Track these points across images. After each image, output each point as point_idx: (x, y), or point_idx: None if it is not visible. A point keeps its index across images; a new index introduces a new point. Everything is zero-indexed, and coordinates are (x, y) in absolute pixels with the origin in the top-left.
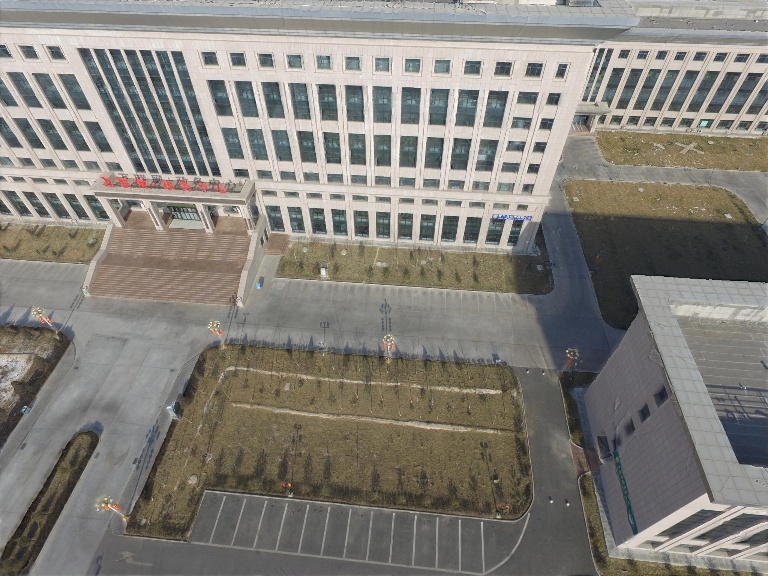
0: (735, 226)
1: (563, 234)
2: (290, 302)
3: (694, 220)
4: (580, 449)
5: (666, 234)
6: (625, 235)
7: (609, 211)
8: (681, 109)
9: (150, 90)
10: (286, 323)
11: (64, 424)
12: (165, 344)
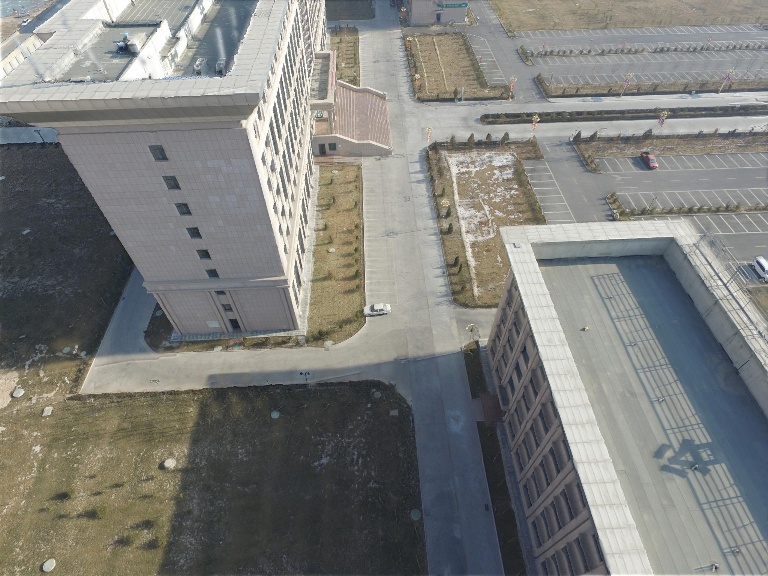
0: None
1: None
2: (379, 85)
3: None
4: (435, 25)
5: None
6: None
7: None
8: None
9: (301, 0)
10: (394, 84)
11: (480, 130)
12: (421, 115)
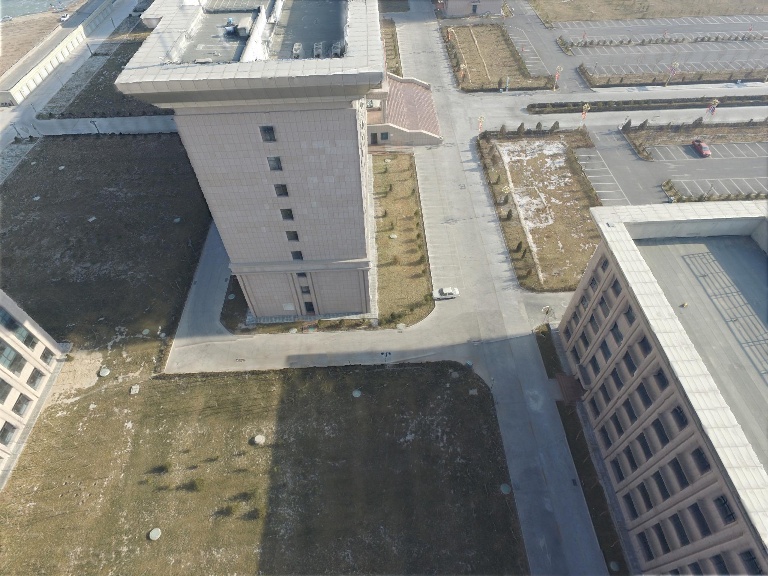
0: None
1: None
2: (421, 76)
3: None
4: (471, 17)
5: None
6: None
7: None
8: None
9: None
10: (437, 75)
11: (528, 119)
12: (467, 105)
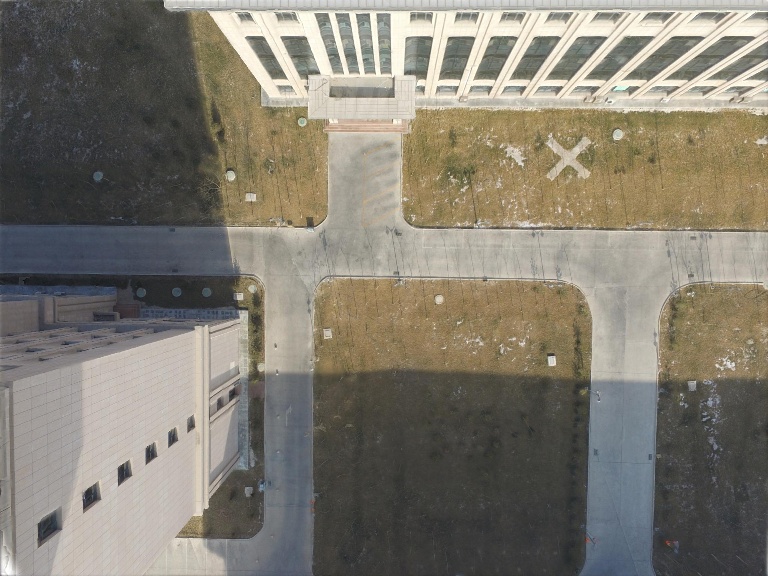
0: (553, 383)
1: (292, 420)
2: None
3: (497, 371)
4: None
5: (444, 407)
6: (383, 413)
7: (374, 358)
8: (572, 79)
9: None
10: None
11: None
12: None
